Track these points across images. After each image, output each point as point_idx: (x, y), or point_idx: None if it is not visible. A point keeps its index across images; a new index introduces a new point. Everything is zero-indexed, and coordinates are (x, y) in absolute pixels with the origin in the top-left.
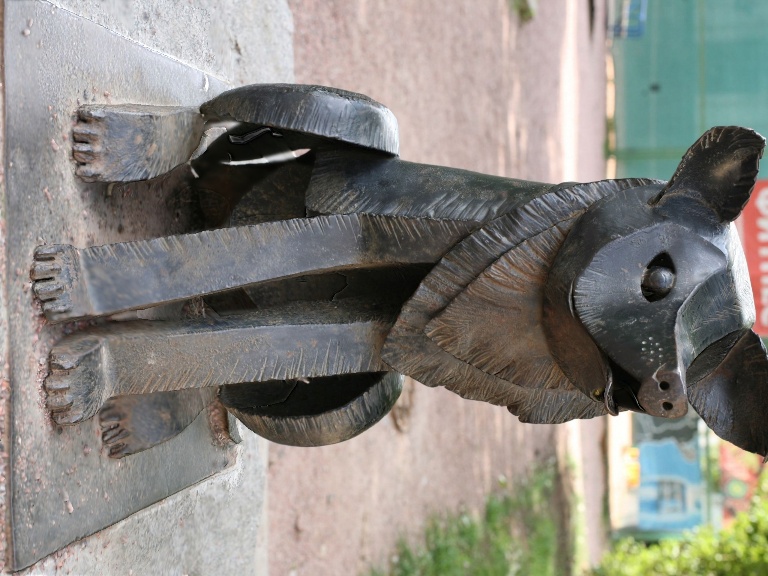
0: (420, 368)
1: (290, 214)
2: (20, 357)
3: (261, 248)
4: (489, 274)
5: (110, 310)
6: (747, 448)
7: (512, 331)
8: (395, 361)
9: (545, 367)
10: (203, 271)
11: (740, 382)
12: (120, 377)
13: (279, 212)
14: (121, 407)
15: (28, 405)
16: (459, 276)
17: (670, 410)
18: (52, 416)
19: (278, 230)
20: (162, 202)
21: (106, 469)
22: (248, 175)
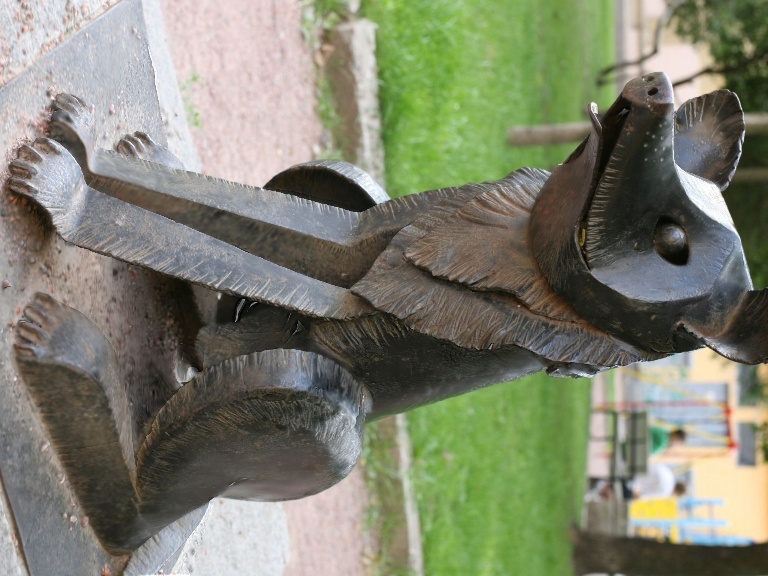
0: (391, 296)
1: (278, 332)
2: (20, 98)
3: (261, 201)
4: (480, 197)
5: (103, 174)
6: (756, 360)
7: (496, 243)
8: (366, 290)
9: (527, 276)
10: (201, 192)
11: (743, 334)
12: (81, 227)
13: (267, 331)
14: (52, 316)
15: (2, 130)
16: (449, 212)
17: (655, 94)
18: (9, 178)
19: (281, 197)
20: (148, 354)
21: (5, 348)
22: (246, 316)
